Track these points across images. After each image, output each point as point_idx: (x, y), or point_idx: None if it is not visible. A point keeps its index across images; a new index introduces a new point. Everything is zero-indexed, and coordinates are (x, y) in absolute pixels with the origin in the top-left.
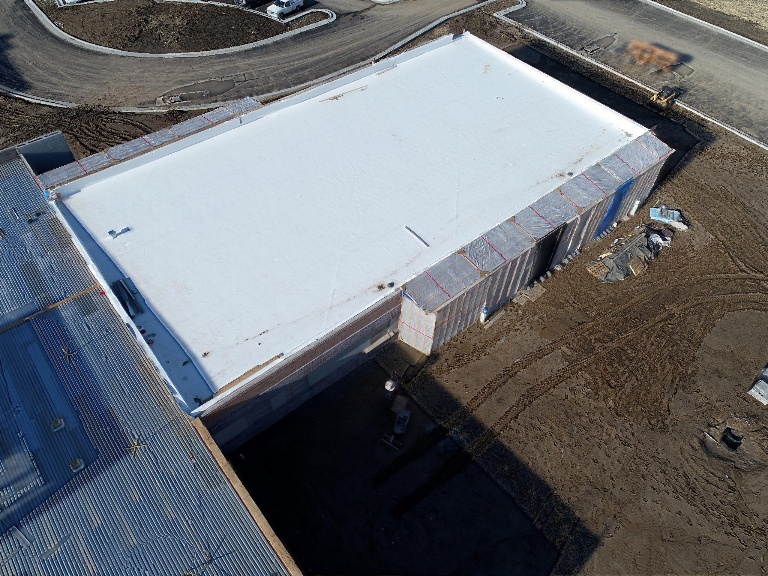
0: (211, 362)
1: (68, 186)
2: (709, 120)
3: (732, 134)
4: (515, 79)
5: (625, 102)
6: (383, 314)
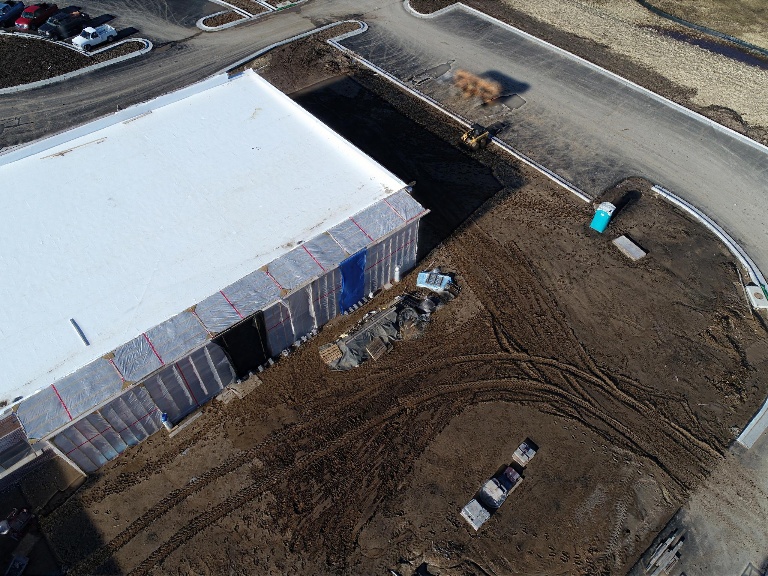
0: None
1: None
2: (523, 161)
3: (544, 177)
4: (283, 125)
5: (434, 142)
6: None
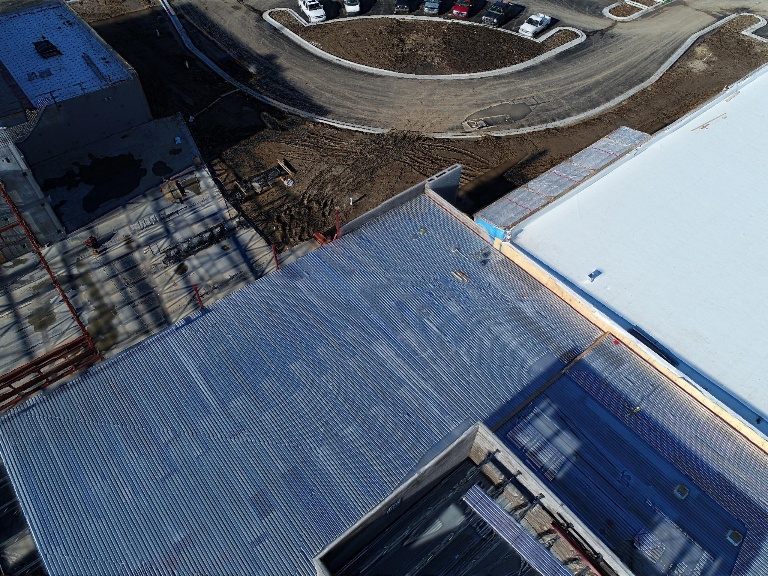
0: None
1: (519, 225)
2: None
3: None
4: None
5: None
6: None
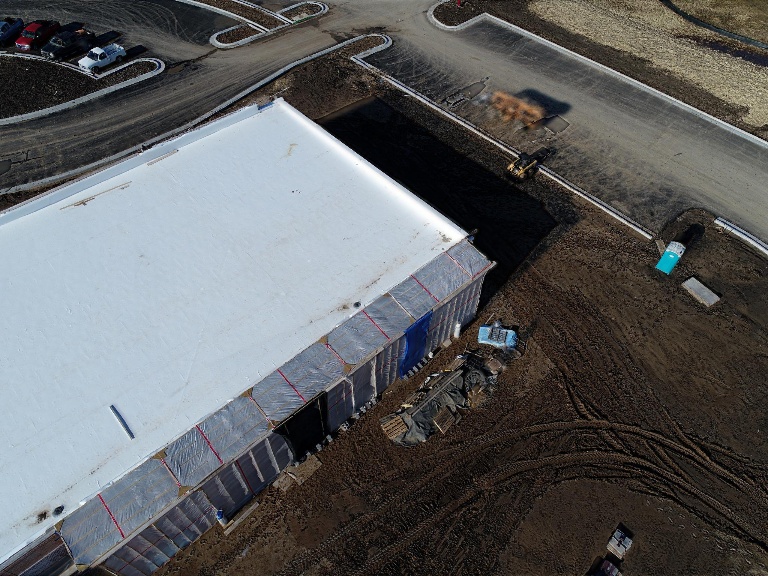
0: None
1: None
2: (575, 193)
3: (600, 211)
4: (323, 163)
5: (479, 172)
6: (37, 561)
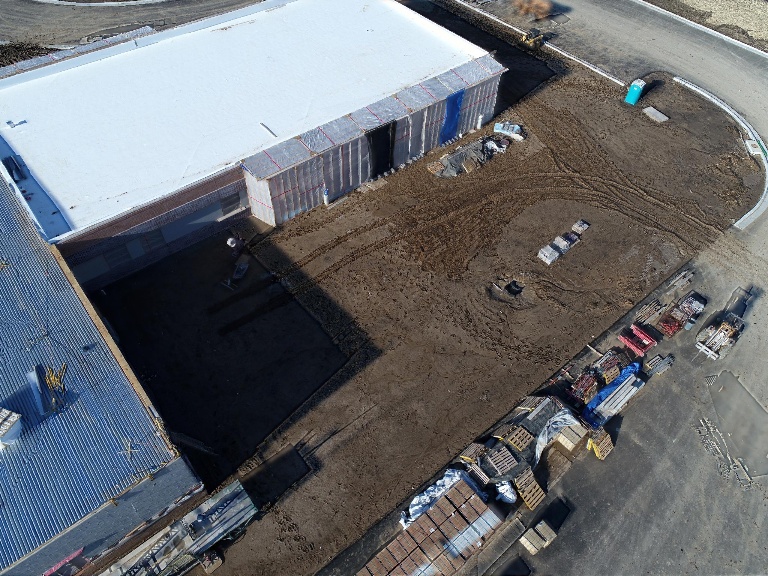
0: (75, 212)
1: None
2: (571, 58)
3: (588, 69)
4: (388, 16)
5: (499, 43)
6: (227, 184)
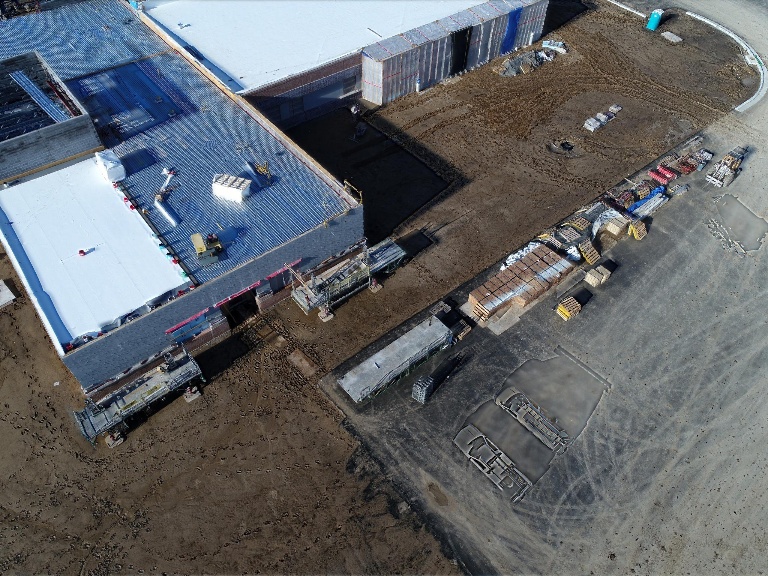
0: (245, 80)
1: (150, 2)
2: None
3: (615, 5)
4: None
5: None
6: (350, 67)
